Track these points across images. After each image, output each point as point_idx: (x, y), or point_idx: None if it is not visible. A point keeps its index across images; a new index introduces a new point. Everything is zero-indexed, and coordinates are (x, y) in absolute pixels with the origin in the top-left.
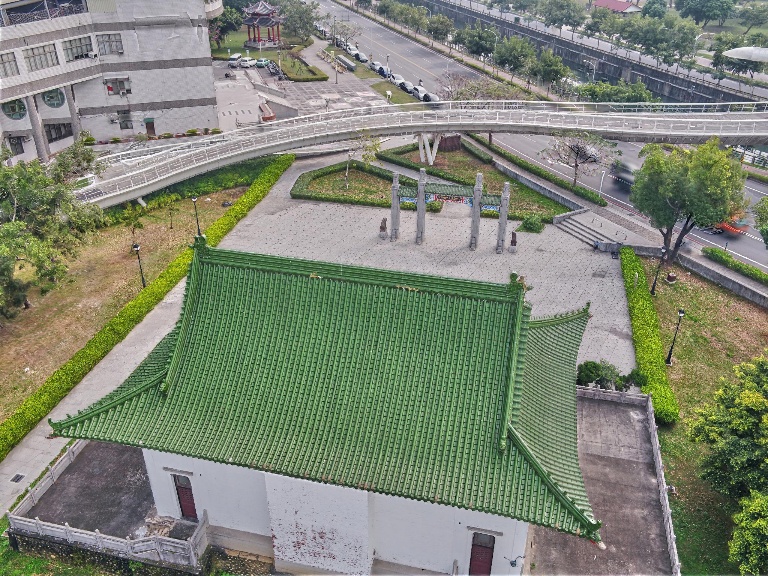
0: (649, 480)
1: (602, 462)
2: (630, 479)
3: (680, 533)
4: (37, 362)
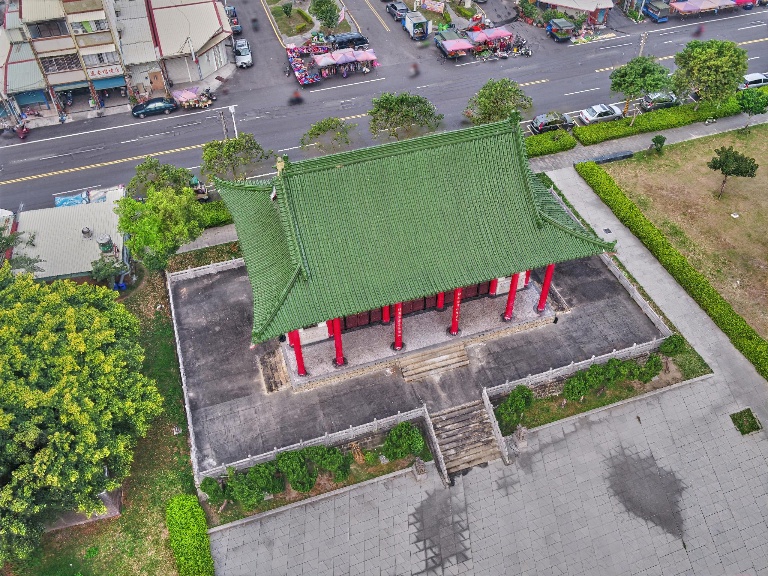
0: (195, 393)
1: (235, 392)
2: (210, 387)
3: (171, 393)
4: (748, 293)
